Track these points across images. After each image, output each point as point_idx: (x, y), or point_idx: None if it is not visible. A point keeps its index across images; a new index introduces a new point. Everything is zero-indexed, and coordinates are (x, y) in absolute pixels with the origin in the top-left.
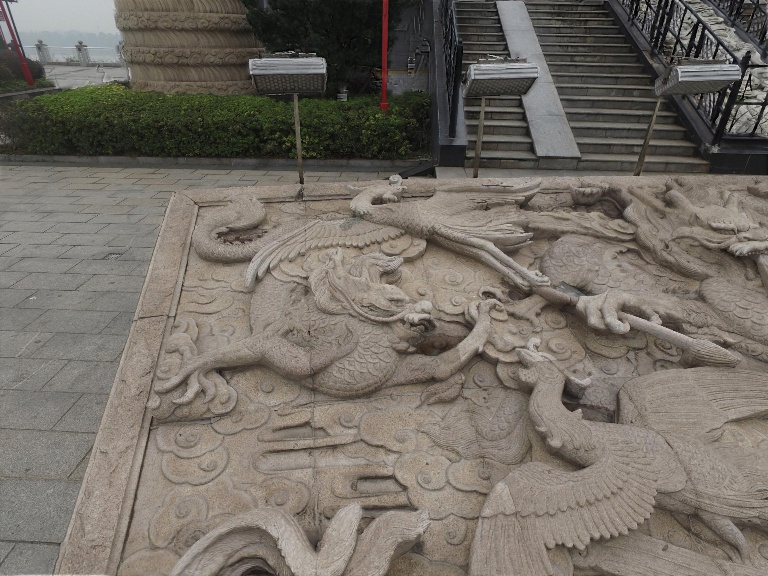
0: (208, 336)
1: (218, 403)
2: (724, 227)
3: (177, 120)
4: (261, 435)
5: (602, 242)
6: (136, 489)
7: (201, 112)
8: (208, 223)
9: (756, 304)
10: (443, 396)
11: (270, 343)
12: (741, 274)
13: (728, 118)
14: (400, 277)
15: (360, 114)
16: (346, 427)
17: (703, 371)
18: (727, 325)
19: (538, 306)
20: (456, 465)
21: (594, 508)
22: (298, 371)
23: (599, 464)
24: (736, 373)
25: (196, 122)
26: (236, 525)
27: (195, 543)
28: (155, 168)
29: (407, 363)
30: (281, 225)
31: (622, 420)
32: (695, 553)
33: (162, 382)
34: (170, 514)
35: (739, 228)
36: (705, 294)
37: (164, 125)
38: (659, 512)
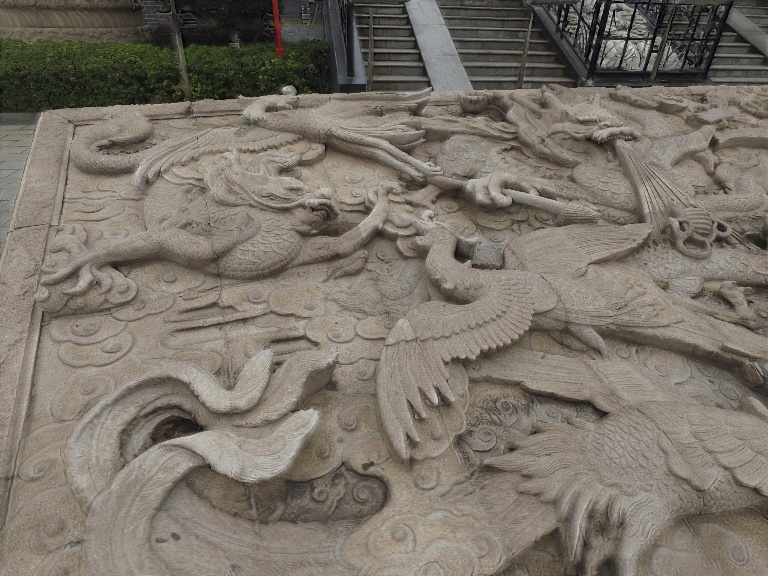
0: (99, 240)
1: (116, 293)
2: (589, 119)
3: (42, 68)
4: (167, 317)
5: (489, 141)
6: (32, 377)
7: (71, 59)
8: (86, 136)
9: (615, 179)
10: (348, 269)
11: (167, 233)
12: (603, 158)
13: (598, 53)
14: (300, 176)
15: (255, 59)
16: (255, 303)
17: (572, 227)
18: (593, 198)
19: (433, 194)
20: (363, 321)
21: (483, 329)
22: (200, 255)
23: (486, 296)
24: (598, 227)
25: (66, 70)
26: (145, 377)
27: (102, 397)
28: (22, 124)
29: (311, 244)
30: (171, 138)
31: (507, 269)
32: (567, 357)
33: (49, 275)
34: (74, 393)
35: (600, 119)
36: (575, 176)
37: (27, 74)
38: (538, 334)
